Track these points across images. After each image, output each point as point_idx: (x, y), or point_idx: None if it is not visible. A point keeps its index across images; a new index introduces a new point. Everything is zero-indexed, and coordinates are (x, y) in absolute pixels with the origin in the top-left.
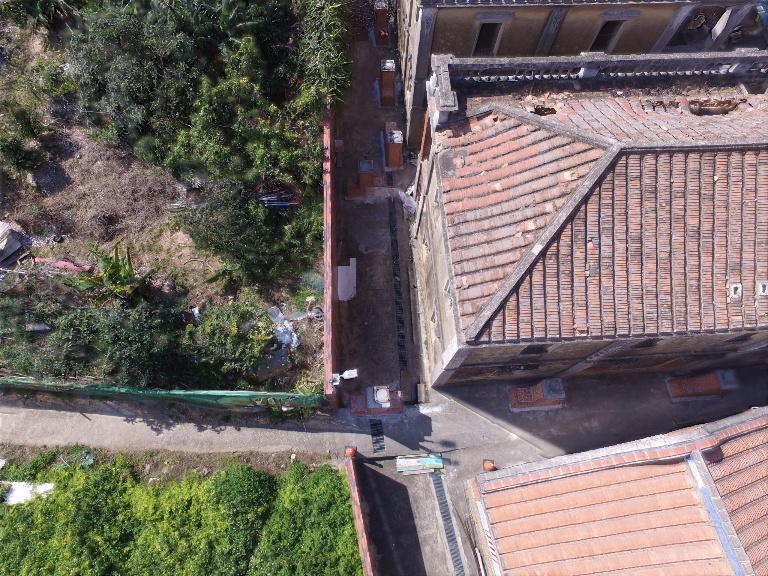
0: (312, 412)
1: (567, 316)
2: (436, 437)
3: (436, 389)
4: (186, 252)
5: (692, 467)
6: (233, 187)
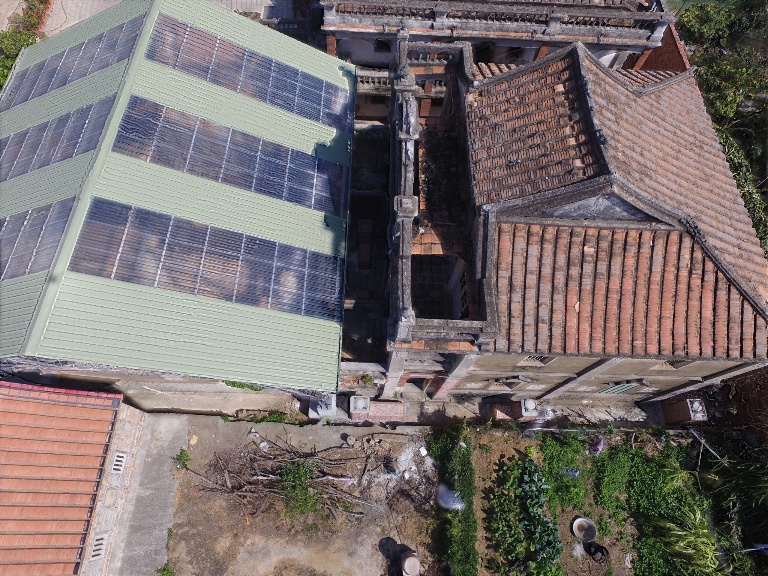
0: None
1: None
2: None
3: None
4: None
5: None
6: None
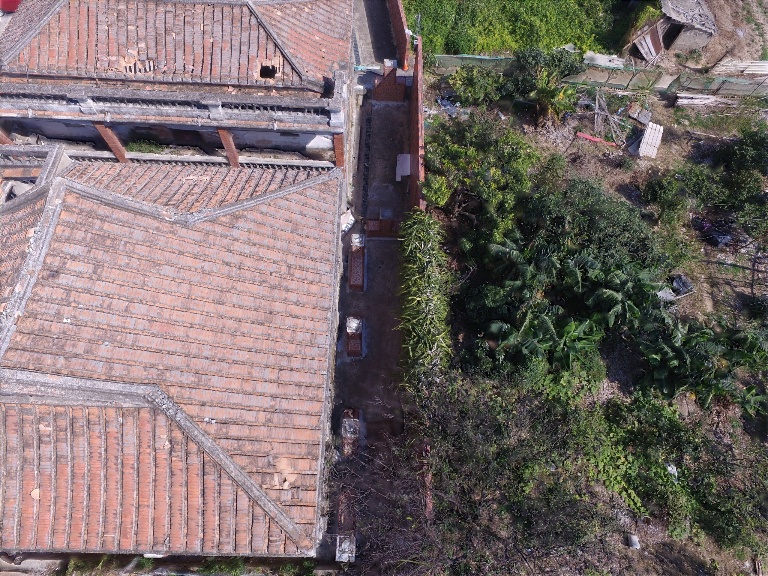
0: None
1: None
2: (356, 76)
3: None
4: None
5: None
6: None
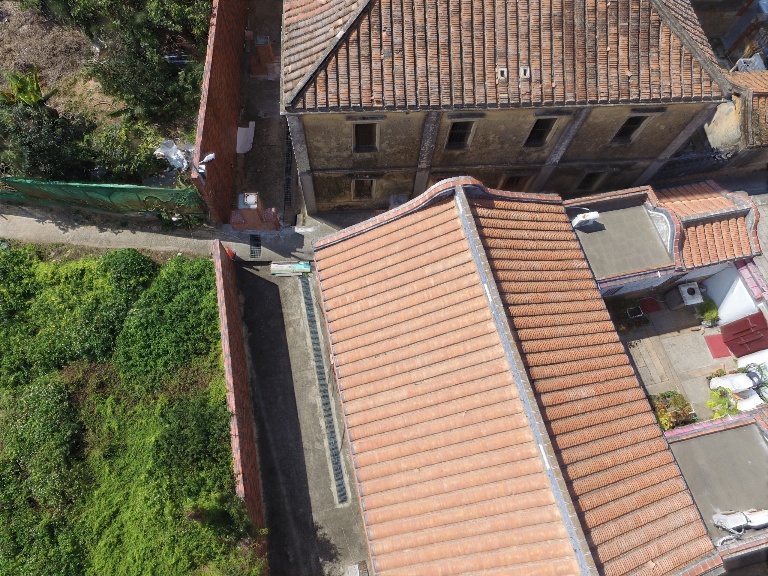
0: (199, 224)
1: (366, 89)
2: (307, 249)
3: (311, 216)
4: (96, 96)
5: (458, 200)
6: (131, 33)
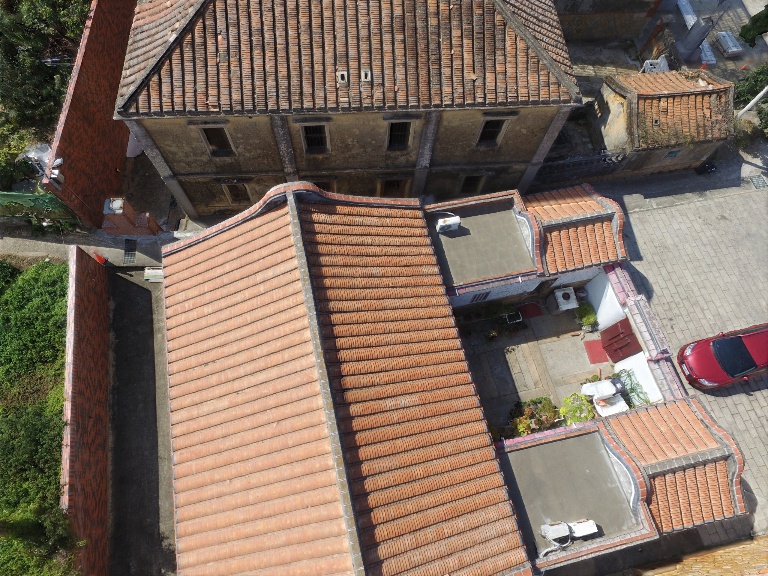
0: (71, 229)
1: (201, 94)
2: None
3: (193, 221)
4: None
5: None
6: (1, 36)
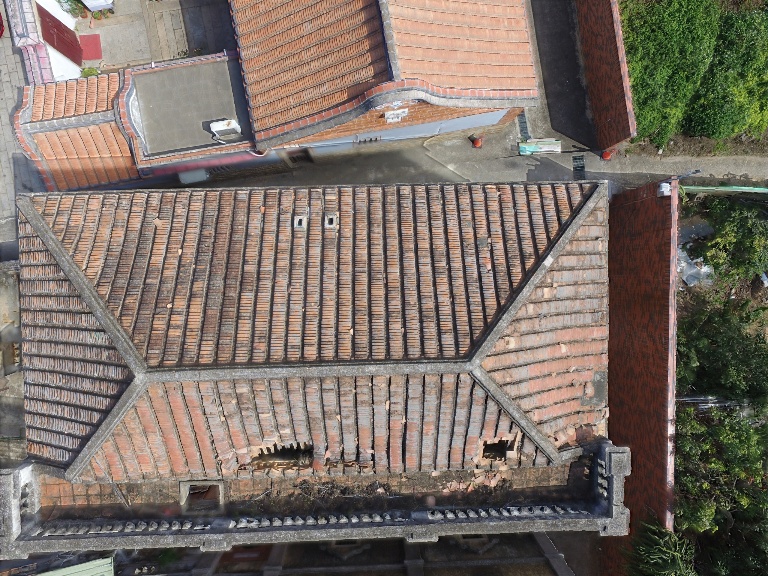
0: None
1: (507, 202)
2: (523, 169)
3: None
4: None
5: (398, 72)
6: None
